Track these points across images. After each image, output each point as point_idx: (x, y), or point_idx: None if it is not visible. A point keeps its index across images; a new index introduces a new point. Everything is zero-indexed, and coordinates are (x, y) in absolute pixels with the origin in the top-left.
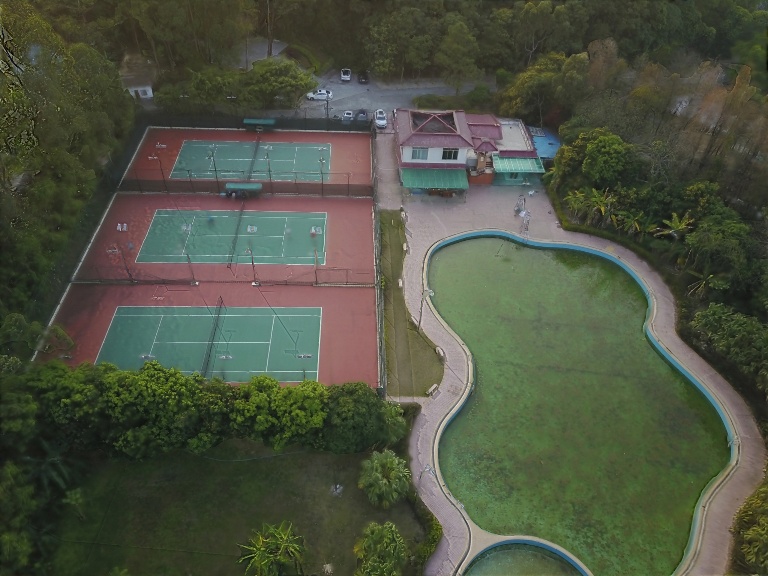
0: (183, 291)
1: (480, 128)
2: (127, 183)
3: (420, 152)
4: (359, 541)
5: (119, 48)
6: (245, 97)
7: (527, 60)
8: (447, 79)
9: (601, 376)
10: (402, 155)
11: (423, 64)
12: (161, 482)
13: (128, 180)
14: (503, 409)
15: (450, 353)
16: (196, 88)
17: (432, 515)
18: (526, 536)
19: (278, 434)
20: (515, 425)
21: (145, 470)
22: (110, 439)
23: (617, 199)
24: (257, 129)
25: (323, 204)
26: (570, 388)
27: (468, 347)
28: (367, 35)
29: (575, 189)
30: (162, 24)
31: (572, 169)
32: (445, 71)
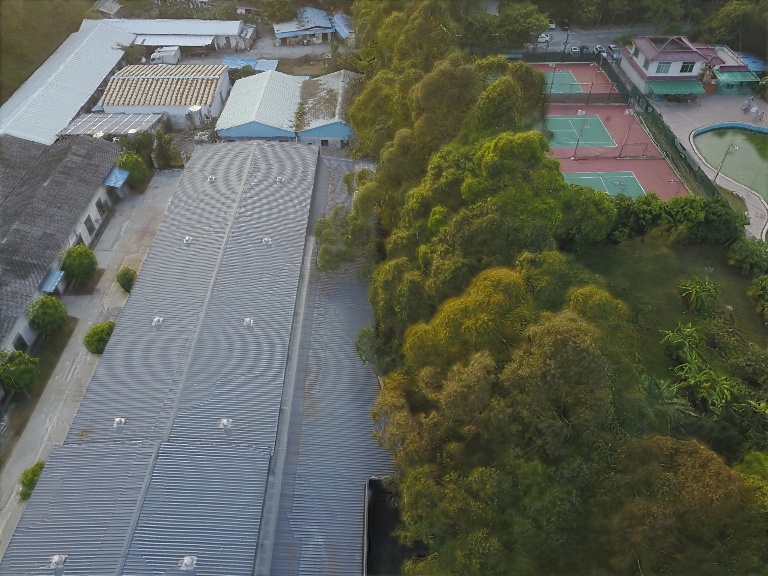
0: None
1: None
2: None
3: (663, 67)
4: (751, 289)
5: None
6: (500, 36)
7: (716, 1)
8: None
9: None
10: (647, 70)
11: (624, 9)
12: None
13: None
14: None
15: (745, 195)
16: (465, 29)
17: None
18: None
19: (674, 227)
20: None
21: None
22: None
23: None
24: None
25: (591, 110)
26: None
27: (756, 192)
28: None
29: None
30: None
31: None
32: (649, 12)
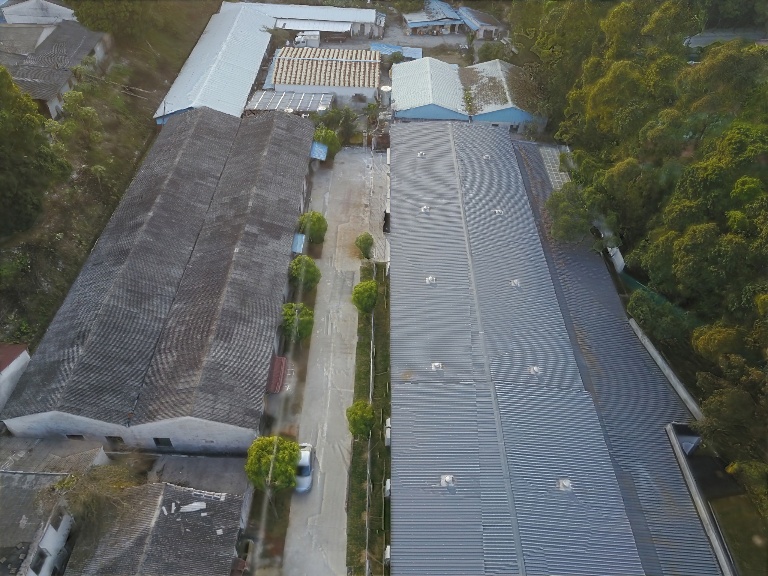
0: None
1: None
2: None
3: None
4: None
5: (491, 2)
6: None
7: None
8: (765, 23)
9: None
10: None
11: (734, 14)
12: None
13: None
14: None
15: None
16: None
17: None
18: None
19: None
20: None
21: None
22: None
23: None
24: None
25: None
26: None
27: None
28: None
29: None
30: None
31: None
32: (761, 17)
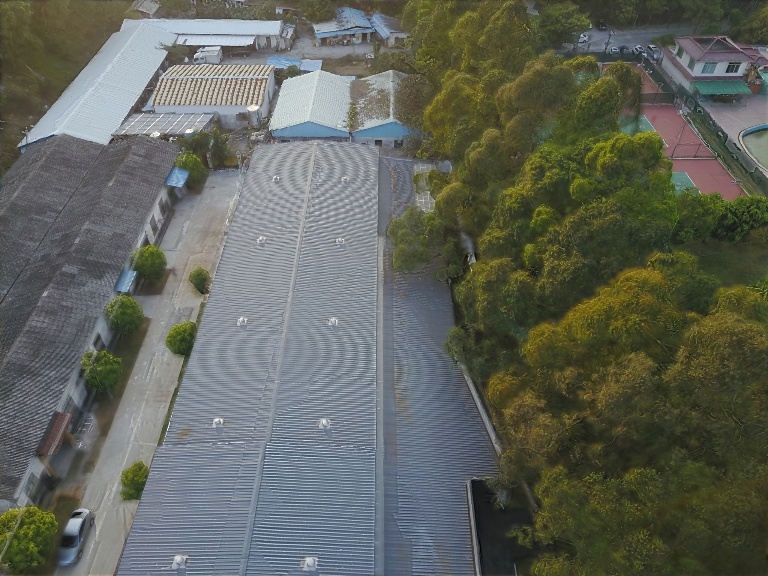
0: None
1: None
2: None
3: (709, 67)
4: None
5: None
6: (542, 36)
7: (755, 1)
8: (692, 18)
9: None
10: (693, 71)
11: (662, 10)
12: None
13: None
14: None
15: None
16: None
17: None
18: None
19: (739, 228)
20: None
21: None
22: None
23: None
24: None
25: None
26: None
27: None
28: None
29: None
30: None
31: None
32: (688, 13)
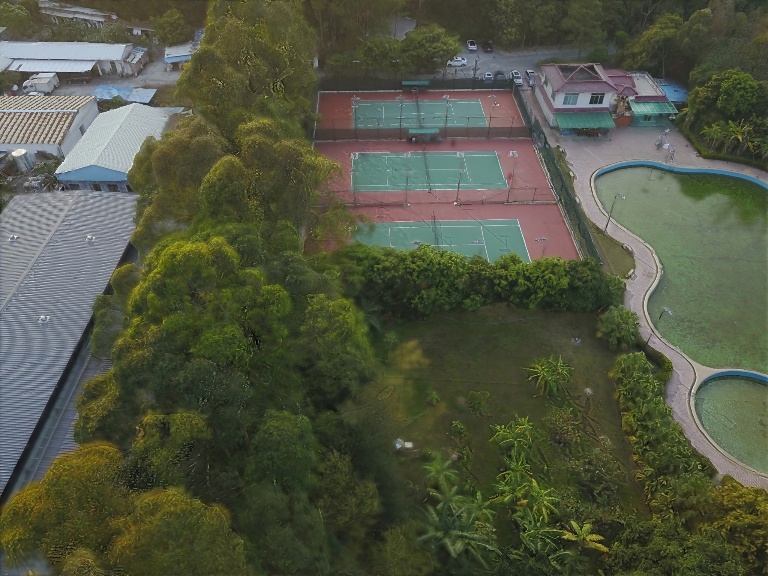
0: (399, 210)
1: (614, 79)
2: (320, 134)
3: (571, 98)
4: (612, 369)
5: None
6: (404, 62)
7: (642, 22)
8: None
9: (766, 263)
10: (554, 102)
11: (546, 31)
12: (436, 338)
13: (325, 130)
14: (690, 288)
15: (636, 249)
16: (364, 55)
17: (662, 354)
18: (739, 369)
19: (533, 295)
20: (703, 299)
21: (420, 331)
22: (408, 298)
23: (753, 128)
24: (412, 90)
25: (490, 145)
26: (742, 272)
27: (649, 244)
28: (492, 9)
29: (710, 124)
30: (338, 0)
31: (706, 107)
32: (570, 35)
